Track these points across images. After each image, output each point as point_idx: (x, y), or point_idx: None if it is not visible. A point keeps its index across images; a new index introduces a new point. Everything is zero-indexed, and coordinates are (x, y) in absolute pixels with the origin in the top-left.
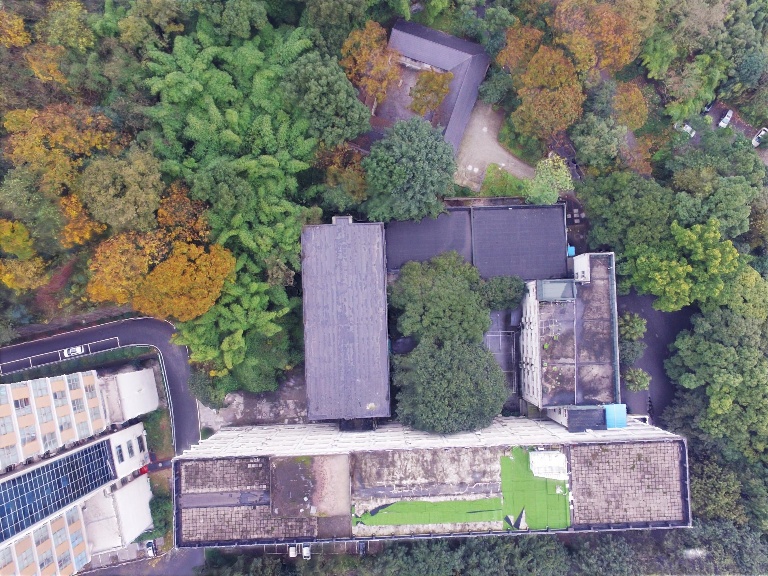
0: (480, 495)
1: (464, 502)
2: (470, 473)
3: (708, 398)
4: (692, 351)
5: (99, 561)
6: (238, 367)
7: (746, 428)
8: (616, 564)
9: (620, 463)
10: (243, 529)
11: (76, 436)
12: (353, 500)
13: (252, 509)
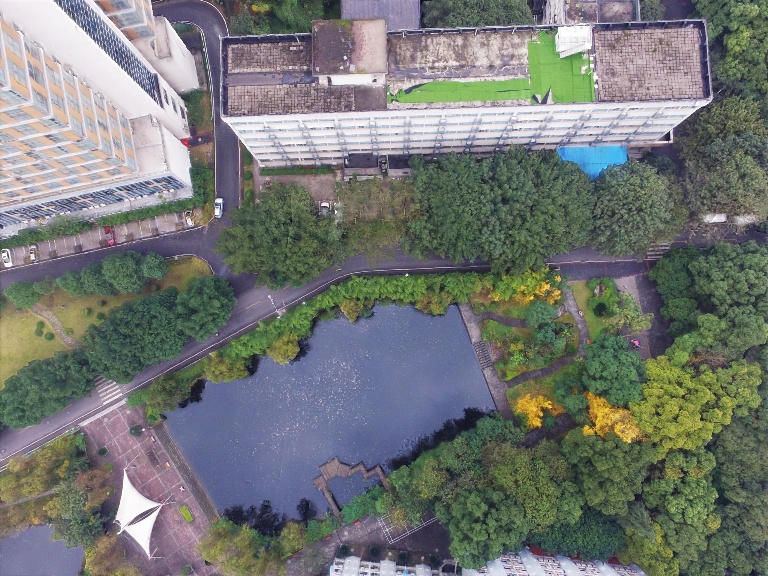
0: (508, 76)
1: (493, 82)
2: (499, 56)
3: (726, 47)
4: (709, 3)
5: (140, 233)
6: (278, 10)
7: (763, 56)
8: (639, 167)
9: (642, 46)
10: (285, 105)
11: (133, 5)
12: (388, 81)
13: (293, 87)
